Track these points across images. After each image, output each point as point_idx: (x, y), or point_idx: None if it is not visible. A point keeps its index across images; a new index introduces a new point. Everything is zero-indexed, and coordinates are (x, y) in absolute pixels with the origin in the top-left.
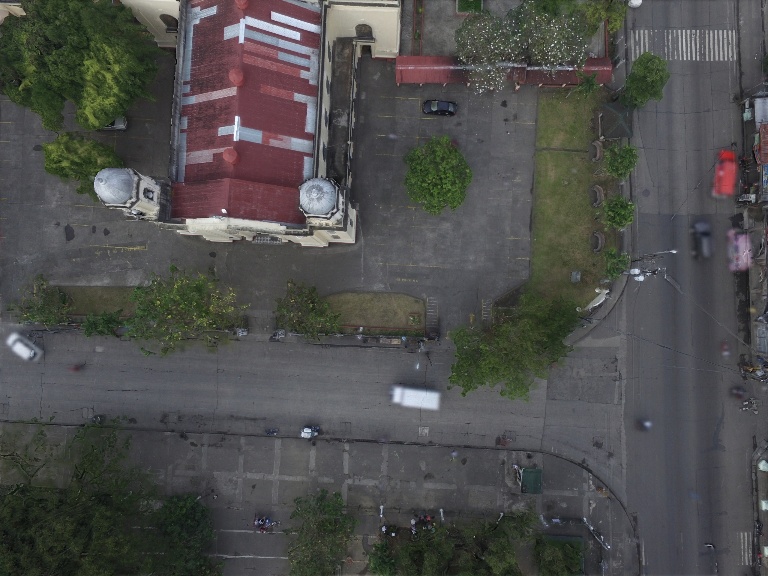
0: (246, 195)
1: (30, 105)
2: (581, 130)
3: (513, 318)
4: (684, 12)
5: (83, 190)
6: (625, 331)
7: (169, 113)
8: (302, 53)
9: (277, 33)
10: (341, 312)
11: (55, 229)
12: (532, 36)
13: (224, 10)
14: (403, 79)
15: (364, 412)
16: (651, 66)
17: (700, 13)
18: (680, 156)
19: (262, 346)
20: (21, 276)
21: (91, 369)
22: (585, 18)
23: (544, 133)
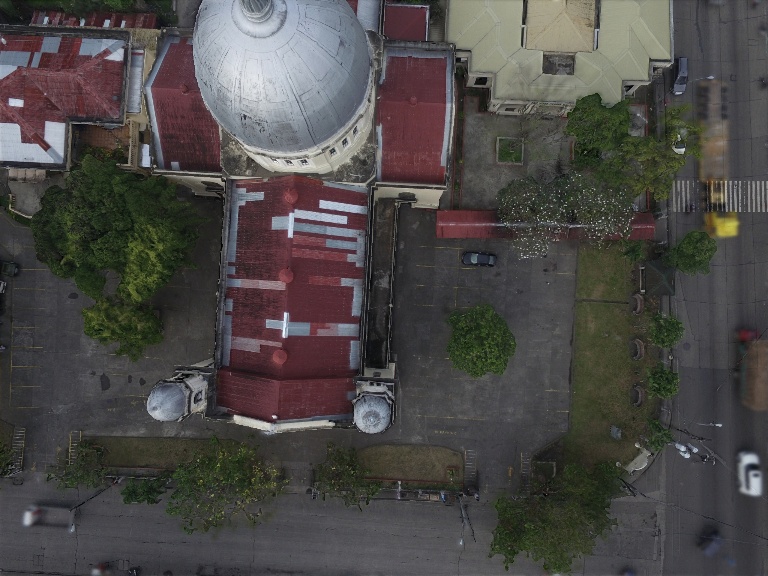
0: (295, 395)
1: (71, 276)
2: (621, 281)
3: (558, 494)
4: (726, 163)
5: (122, 352)
6: (665, 486)
7: (206, 261)
8: (349, 236)
9: (325, 221)
10: (379, 464)
11: (90, 378)
12: (578, 208)
13: (272, 199)
14: (444, 234)
15: (401, 566)
16: (700, 247)
17: (742, 164)
18: (721, 309)
19: (299, 499)
20: (56, 426)
21: (127, 521)
22: (632, 190)
23: (584, 284)
